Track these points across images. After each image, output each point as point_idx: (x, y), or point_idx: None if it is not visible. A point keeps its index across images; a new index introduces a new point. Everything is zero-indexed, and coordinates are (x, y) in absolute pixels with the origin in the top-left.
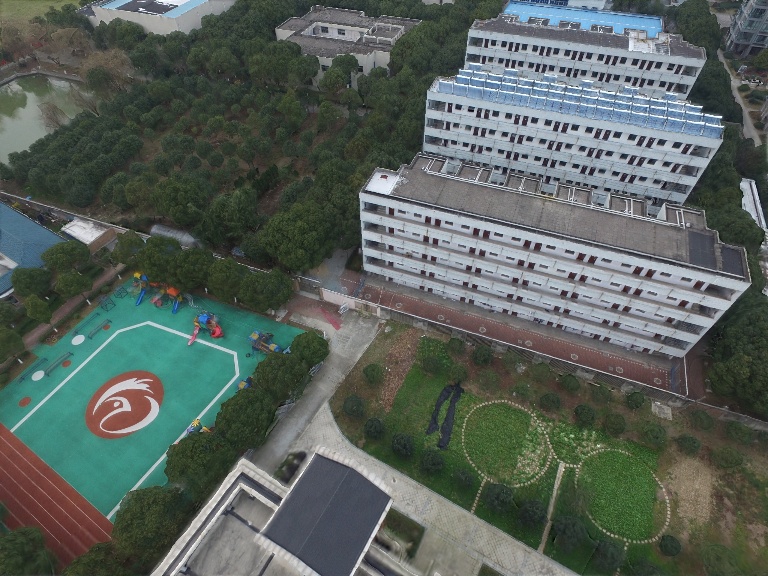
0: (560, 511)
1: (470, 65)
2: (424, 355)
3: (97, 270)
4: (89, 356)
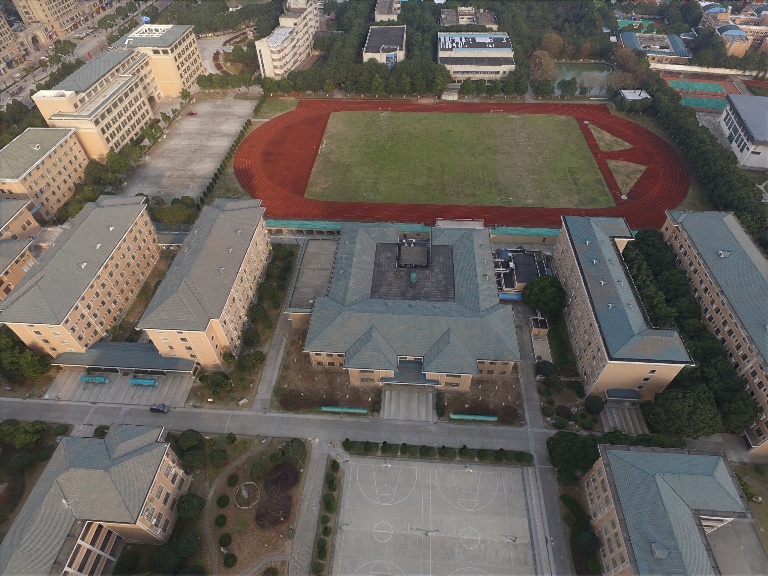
0: None
1: None
2: None
3: None
4: None
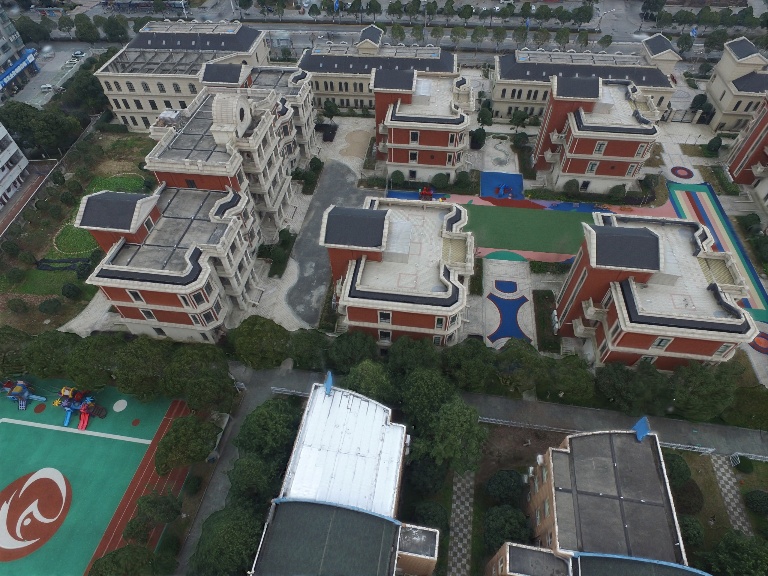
0: None
1: None
2: (3, 288)
3: None
4: None
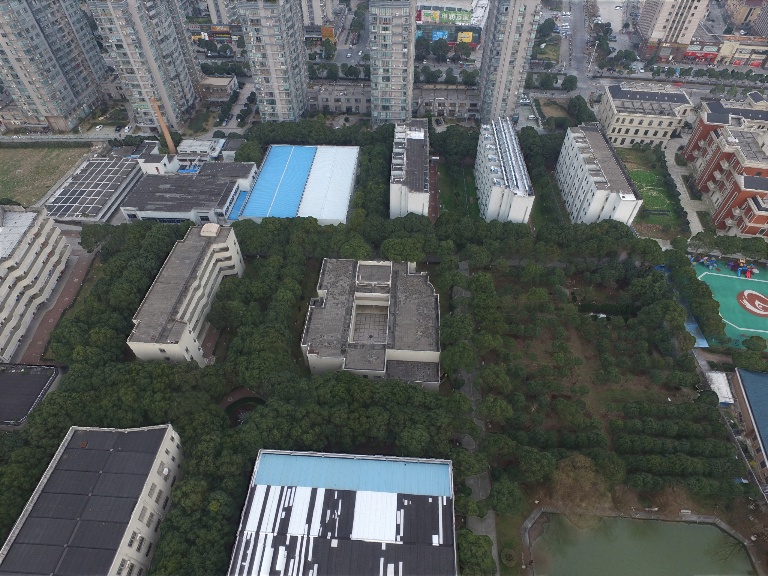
0: (661, 187)
1: (497, 183)
2: (639, 221)
3: (727, 365)
4: (760, 332)
